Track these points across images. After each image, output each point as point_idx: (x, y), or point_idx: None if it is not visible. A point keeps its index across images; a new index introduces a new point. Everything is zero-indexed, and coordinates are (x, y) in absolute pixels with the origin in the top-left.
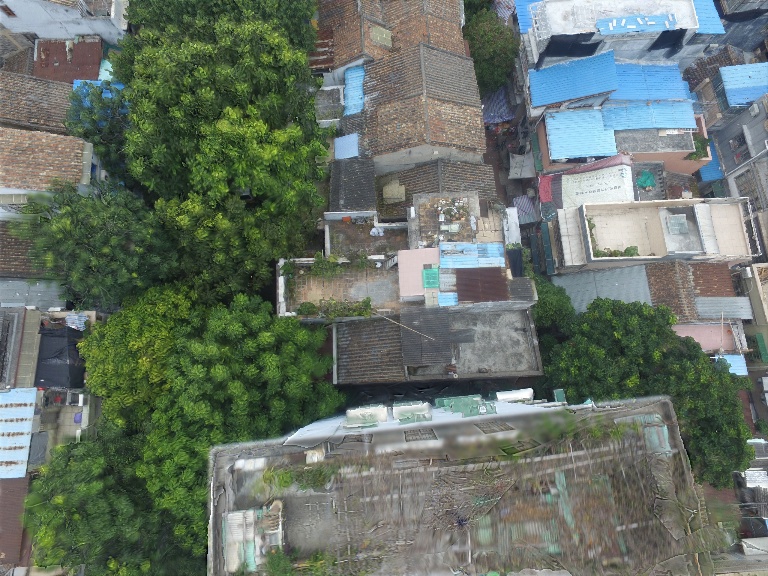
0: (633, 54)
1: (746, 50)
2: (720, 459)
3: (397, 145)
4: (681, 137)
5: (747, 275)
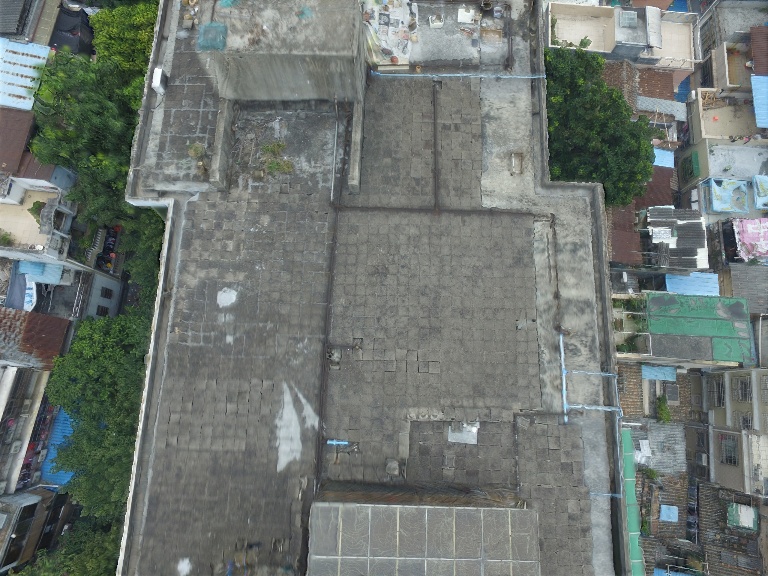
0: None
1: None
2: (620, 165)
3: None
4: None
5: (691, 97)
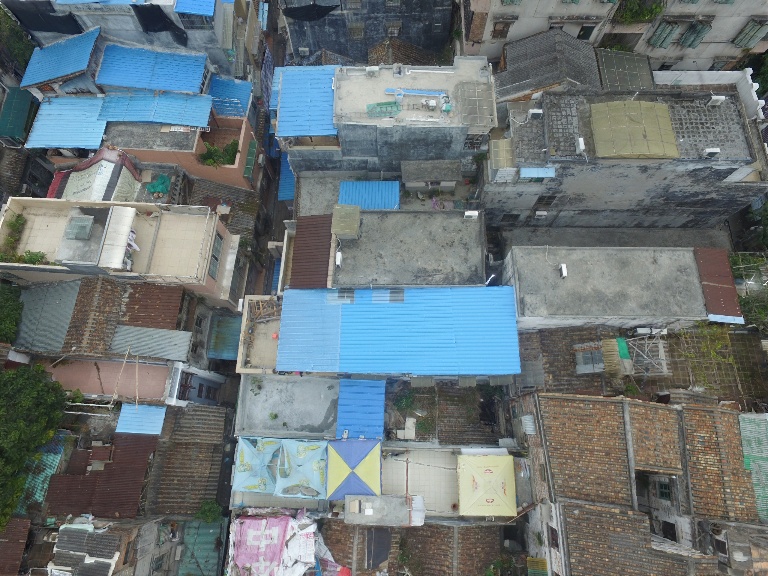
0: (135, 36)
1: (360, 61)
2: None
3: None
4: (185, 135)
5: None
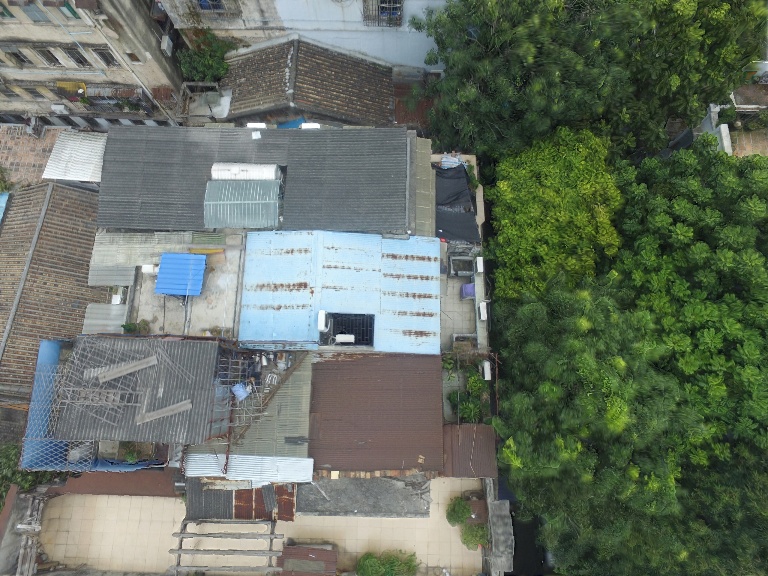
0: None
1: None
2: None
3: None
4: None
5: None
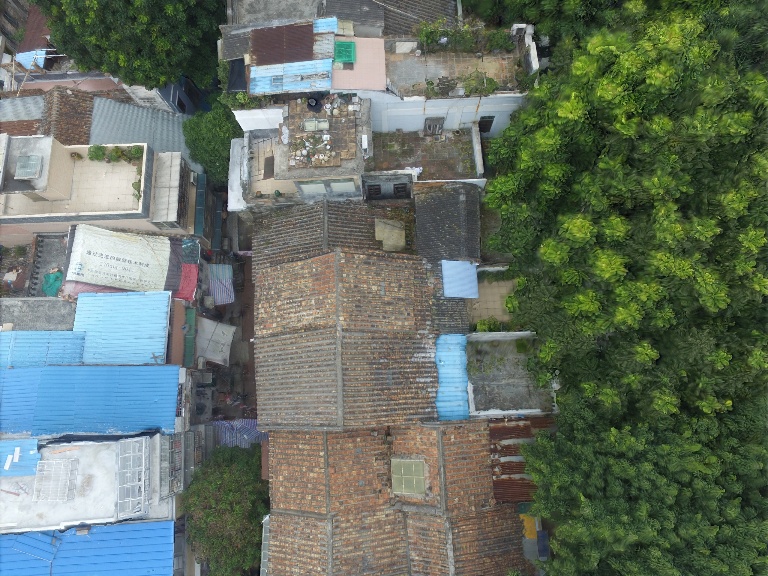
0: None
1: None
2: None
3: (385, 259)
4: None
5: None
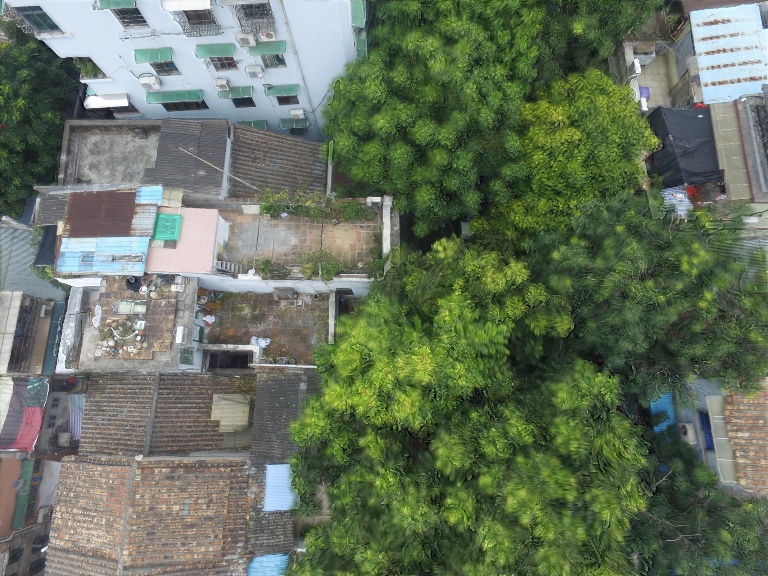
0: None
1: None
2: None
3: (194, 470)
4: None
5: None
